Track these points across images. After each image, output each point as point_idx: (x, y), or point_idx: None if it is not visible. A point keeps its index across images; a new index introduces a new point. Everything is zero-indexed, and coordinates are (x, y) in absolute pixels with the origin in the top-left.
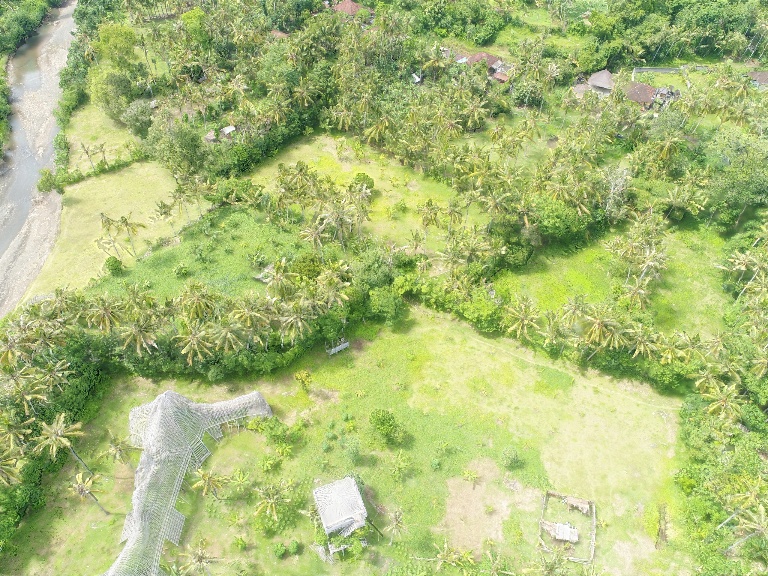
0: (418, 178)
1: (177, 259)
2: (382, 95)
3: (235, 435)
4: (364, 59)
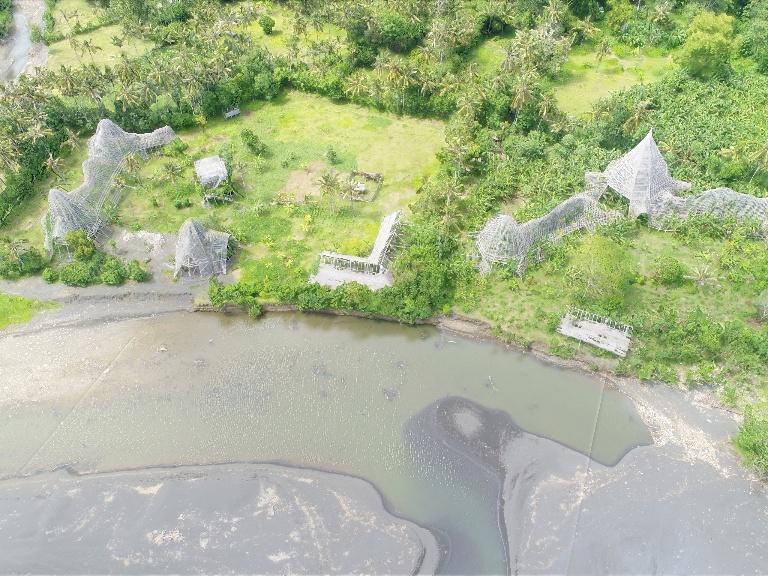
0: None
1: None
2: None
3: (158, 159)
4: None
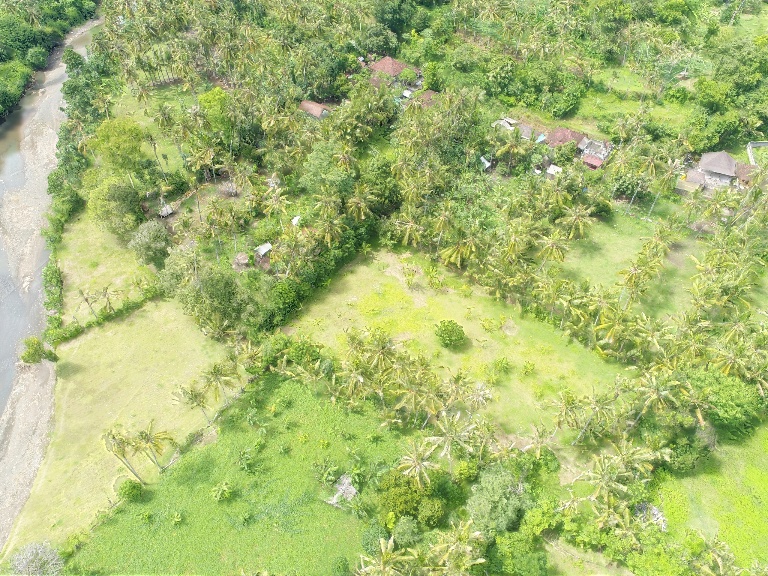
0: (514, 315)
1: (215, 467)
2: (451, 193)
3: None
4: (426, 146)
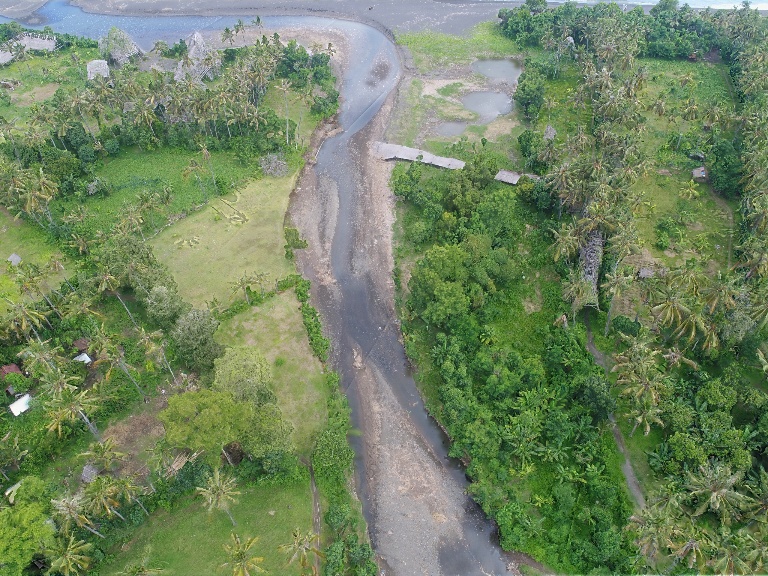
0: None
1: (173, 202)
2: None
3: None
4: None
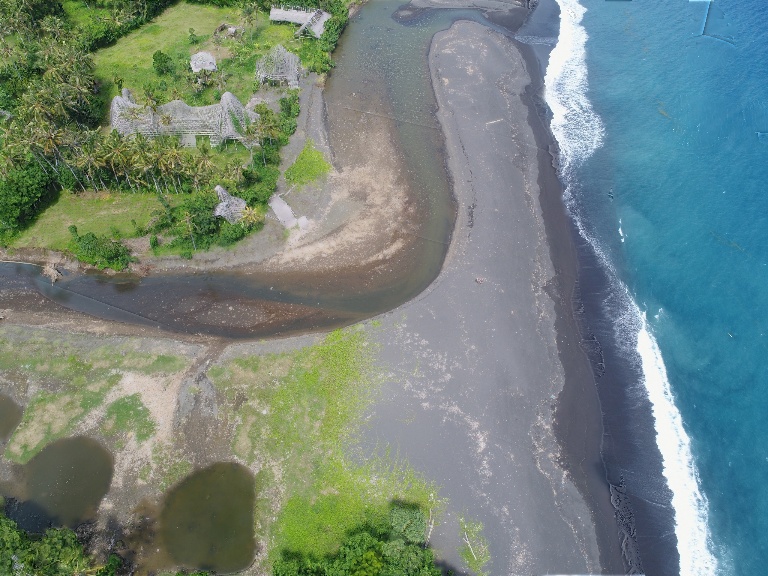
0: None
1: None
2: None
3: None
4: None
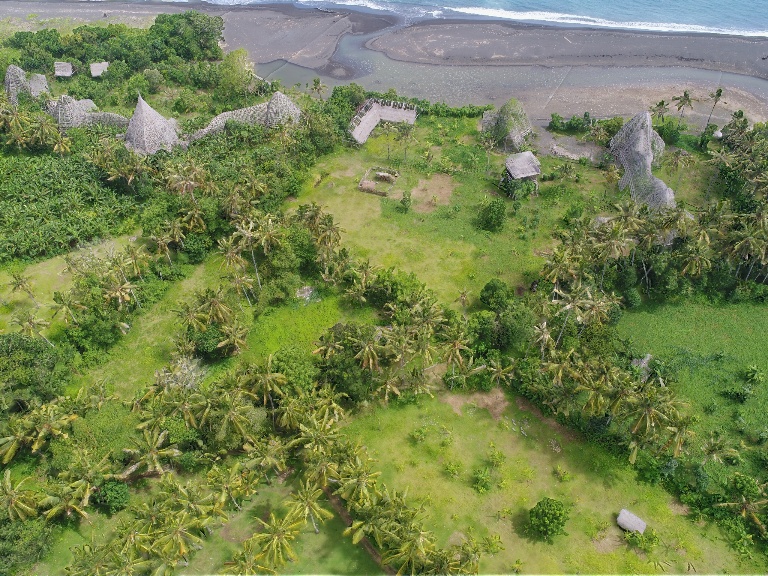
0: None
1: None
2: None
3: None
4: None
